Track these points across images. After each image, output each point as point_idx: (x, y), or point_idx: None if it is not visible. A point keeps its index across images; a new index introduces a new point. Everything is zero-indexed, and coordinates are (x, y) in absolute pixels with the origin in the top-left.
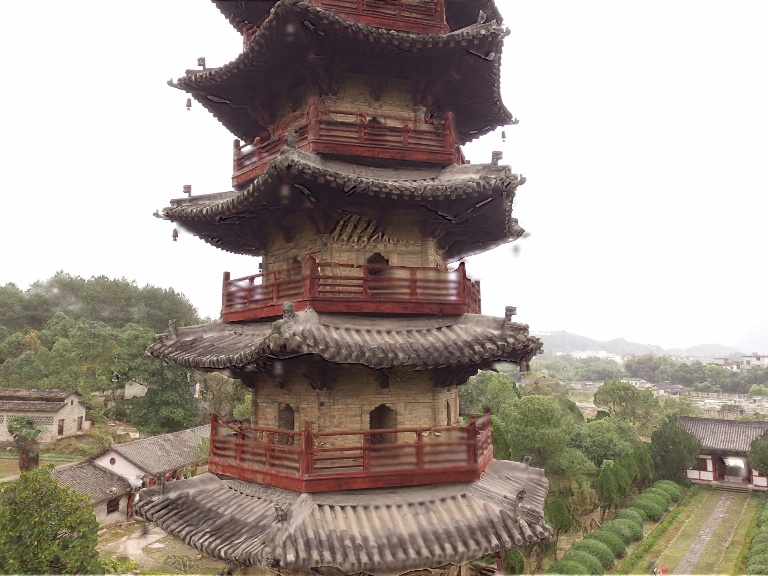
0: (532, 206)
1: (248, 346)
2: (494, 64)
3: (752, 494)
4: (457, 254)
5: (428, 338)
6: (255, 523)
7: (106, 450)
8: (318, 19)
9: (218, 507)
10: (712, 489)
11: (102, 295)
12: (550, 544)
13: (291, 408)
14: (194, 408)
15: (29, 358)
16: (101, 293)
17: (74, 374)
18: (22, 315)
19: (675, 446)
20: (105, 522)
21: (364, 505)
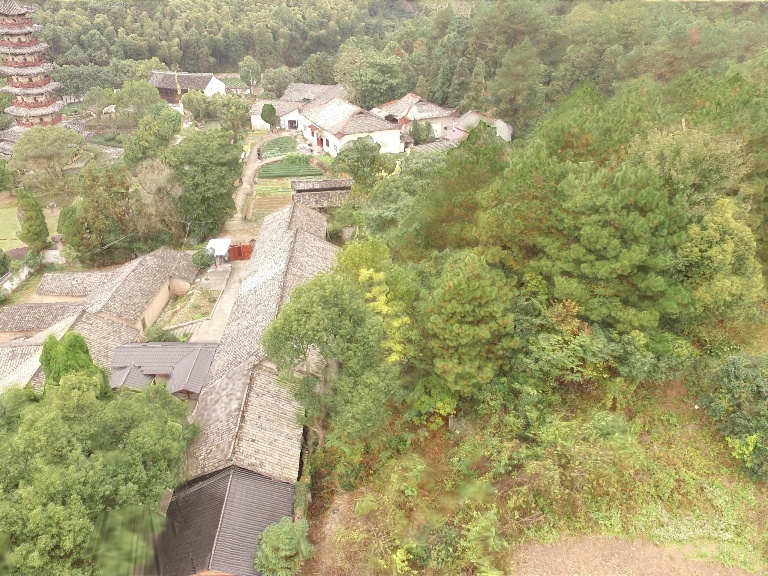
0: None
1: None
2: None
3: None
4: None
5: None
6: None
7: None
8: None
9: None
10: None
11: None
12: None
13: None
14: None
15: None
16: None
17: None
18: None
19: None
20: None
21: None
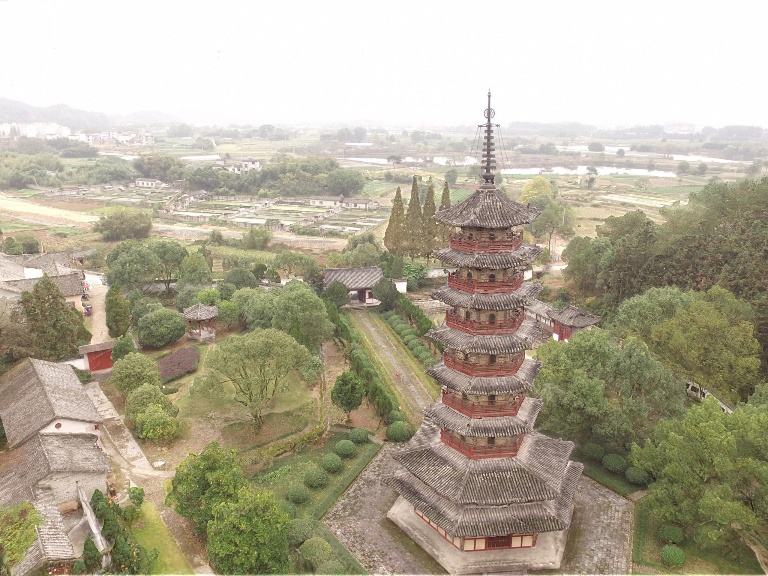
0: (54, 5)
1: (501, 386)
2: None
3: (370, 310)
4: None
5: None
6: (505, 426)
7: (53, 420)
8: None
9: (486, 426)
10: (350, 310)
11: None
12: (372, 380)
13: (494, 395)
14: None
15: None
16: None
17: None
18: None
19: (341, 294)
20: None
21: None
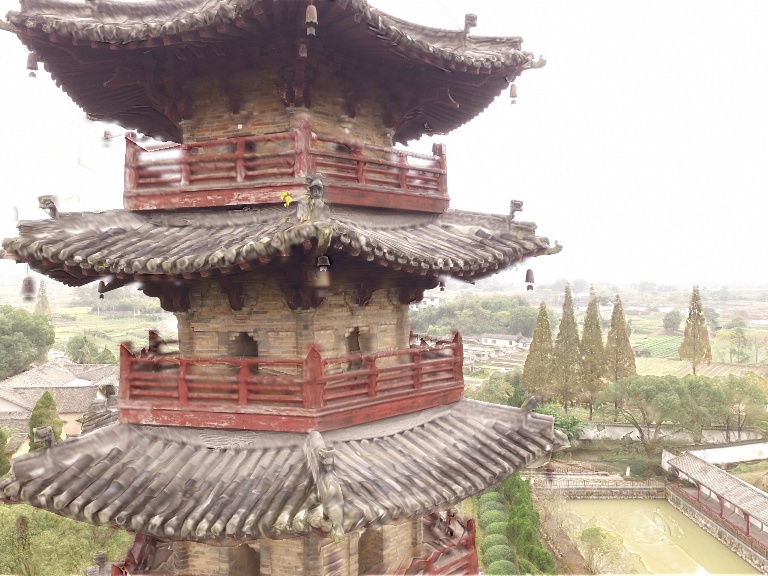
0: None
1: None
2: None
3: None
4: None
5: None
6: None
7: None
8: None
9: None
10: None
11: None
12: None
13: None
14: None
15: None
16: None
17: None
18: None
19: None
20: None
21: None
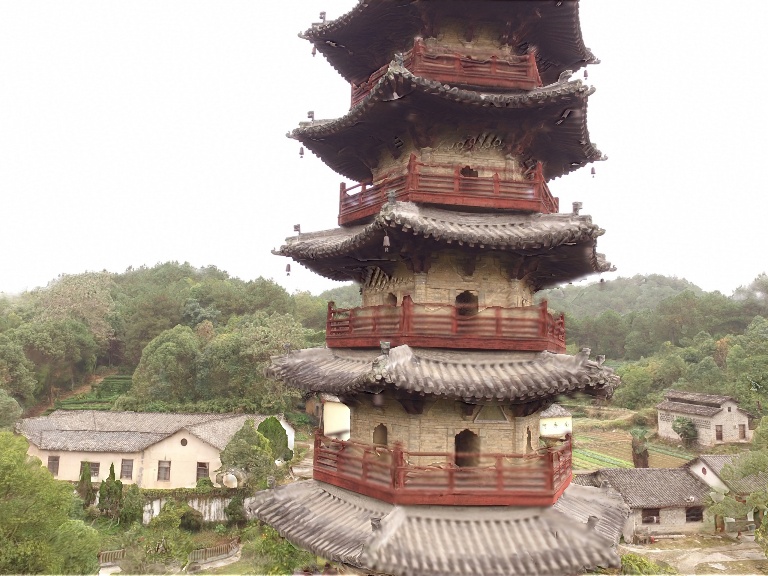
0: None
1: None
2: (424, 92)
3: None
4: (530, 271)
5: (370, 368)
6: None
7: None
8: (307, 136)
9: None
10: None
11: None
12: None
13: None
14: None
15: (708, 363)
16: None
17: (747, 380)
18: (726, 321)
19: None
20: (685, 528)
21: (344, 500)
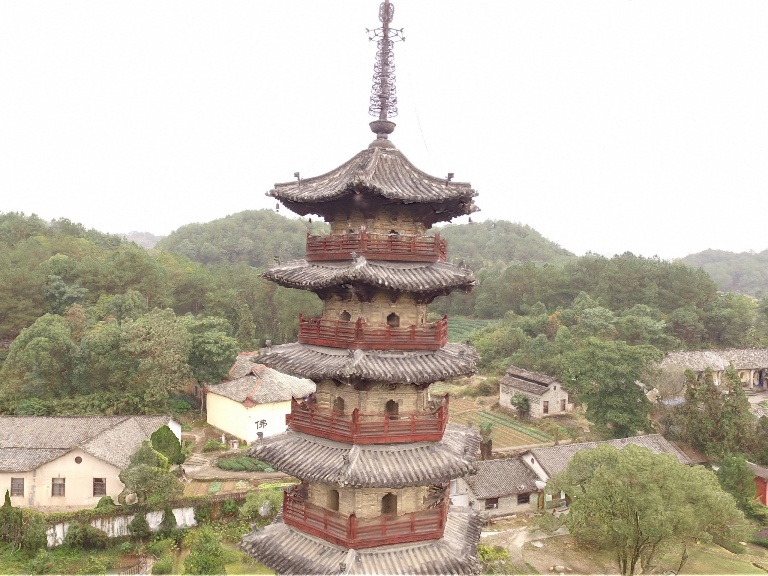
0: None
1: None
2: None
3: None
4: None
5: (325, 559)
6: None
7: (528, 451)
8: None
9: None
10: None
11: (617, 276)
12: None
13: None
14: (643, 413)
15: (542, 340)
16: (617, 273)
17: (570, 358)
18: (558, 292)
19: None
20: (516, 509)
21: None
